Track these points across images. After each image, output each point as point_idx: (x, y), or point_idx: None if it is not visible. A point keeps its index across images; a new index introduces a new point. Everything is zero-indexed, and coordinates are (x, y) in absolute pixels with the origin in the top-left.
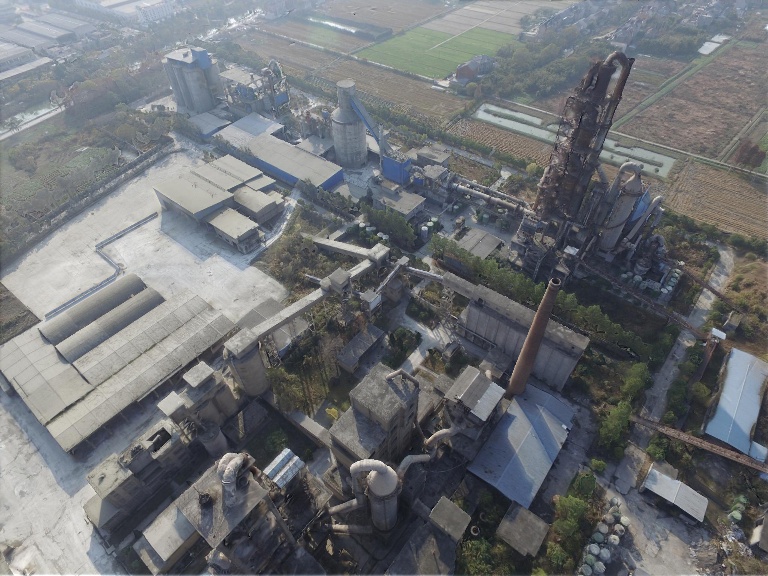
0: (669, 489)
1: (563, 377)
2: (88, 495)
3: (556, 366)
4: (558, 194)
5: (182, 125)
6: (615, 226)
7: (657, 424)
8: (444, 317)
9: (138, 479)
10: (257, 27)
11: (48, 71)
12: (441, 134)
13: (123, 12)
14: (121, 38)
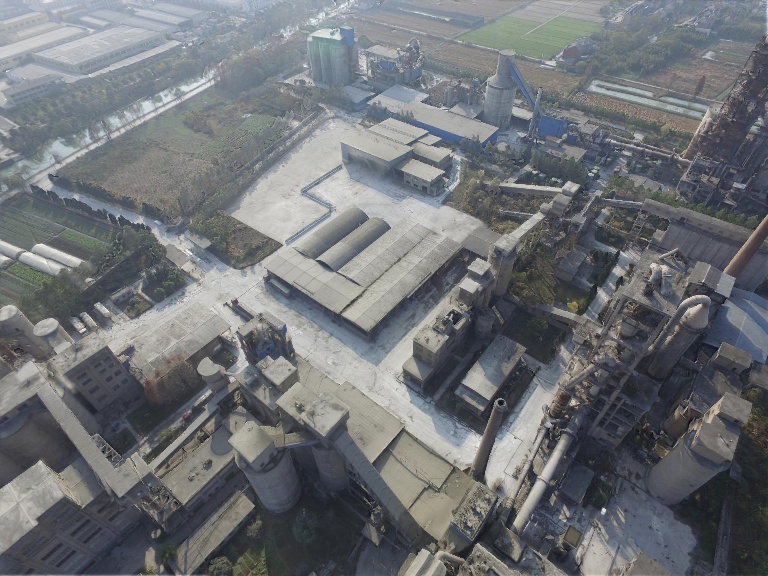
0: None
1: (759, 279)
2: (390, 365)
3: (755, 270)
4: (721, 140)
5: (334, 95)
6: None
7: None
8: (631, 242)
9: (446, 345)
10: (355, 16)
11: (180, 52)
12: (570, 103)
13: (227, 2)
14: (234, 25)
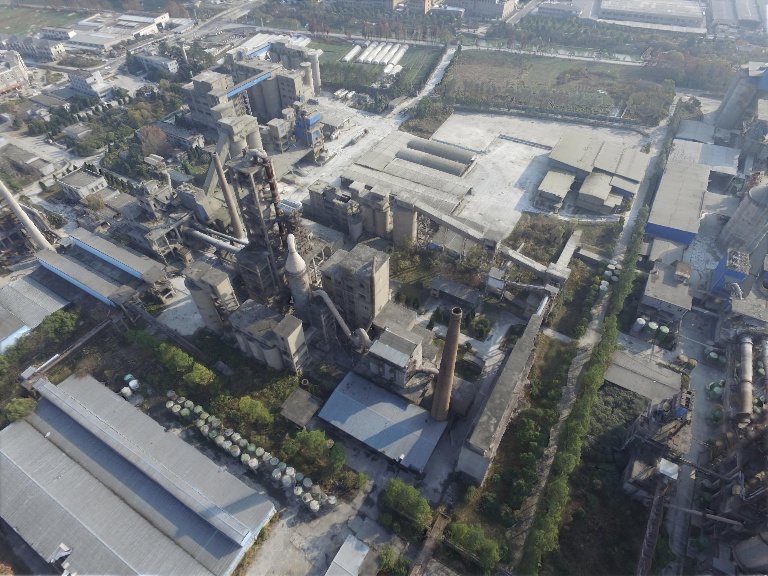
0: (347, 560)
1: None
2: None
3: None
4: (767, 431)
5: None
6: (764, 538)
7: (424, 567)
8: None
9: (323, 202)
10: None
11: None
12: None
13: None
14: None
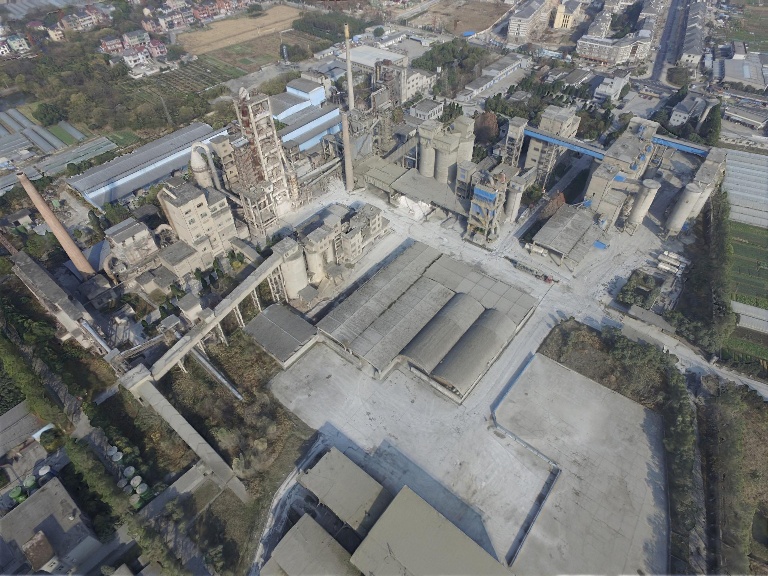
0: (49, 231)
1: None
2: (399, 238)
3: None
4: None
5: None
6: None
7: None
8: None
9: None
10: None
11: None
12: None
13: None
14: None
